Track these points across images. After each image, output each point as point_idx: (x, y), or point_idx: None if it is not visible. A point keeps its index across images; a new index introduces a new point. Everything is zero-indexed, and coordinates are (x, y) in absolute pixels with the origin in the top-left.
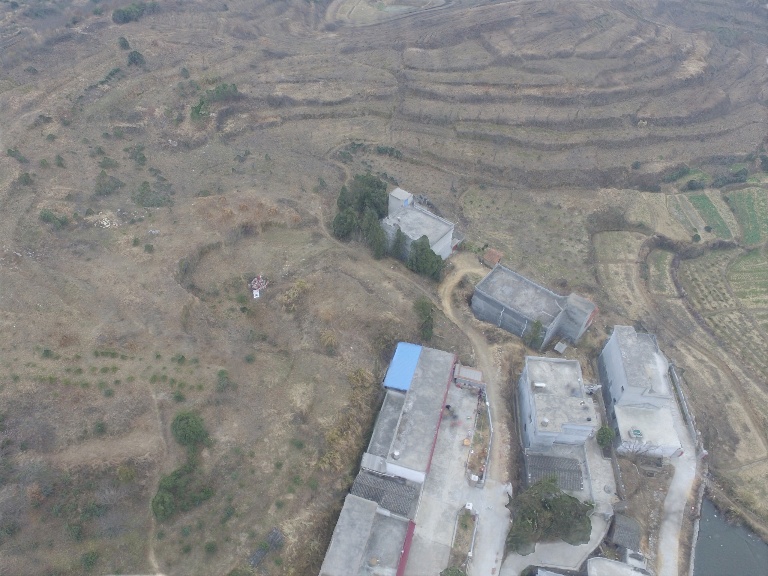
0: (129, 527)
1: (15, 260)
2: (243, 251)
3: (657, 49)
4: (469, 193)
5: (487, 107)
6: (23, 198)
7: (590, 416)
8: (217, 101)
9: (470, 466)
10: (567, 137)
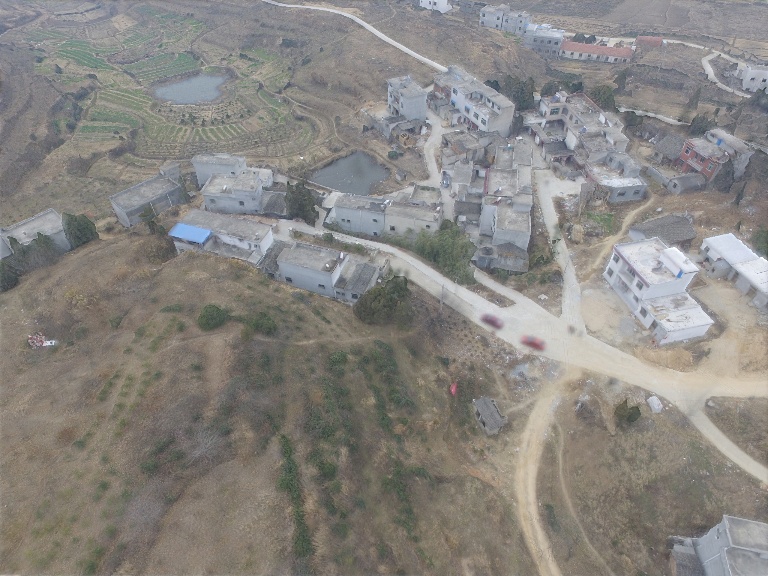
0: None
1: None
2: None
3: None
4: None
5: None
6: None
7: (252, 172)
8: None
9: None
10: None
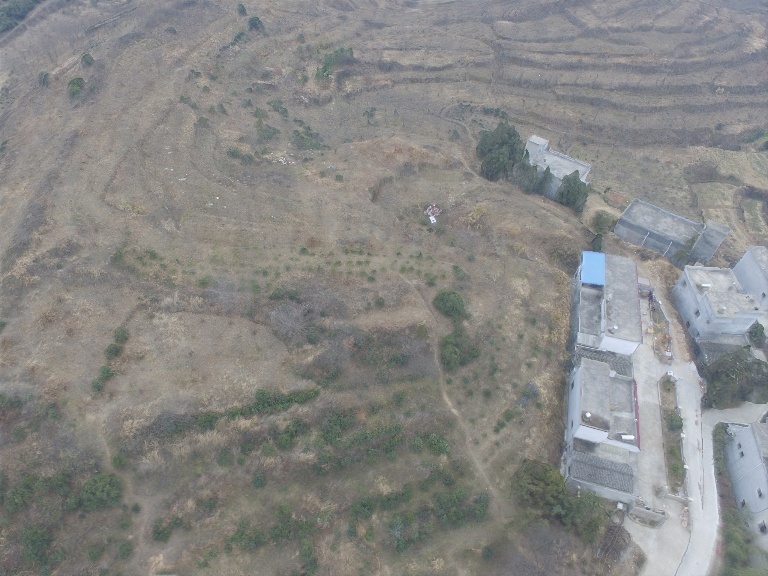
0: (425, 373)
1: (230, 185)
2: (411, 185)
3: (722, 26)
4: (573, 149)
5: (582, 73)
6: (207, 138)
7: (756, 306)
8: (333, 64)
9: (657, 348)
10: (656, 101)
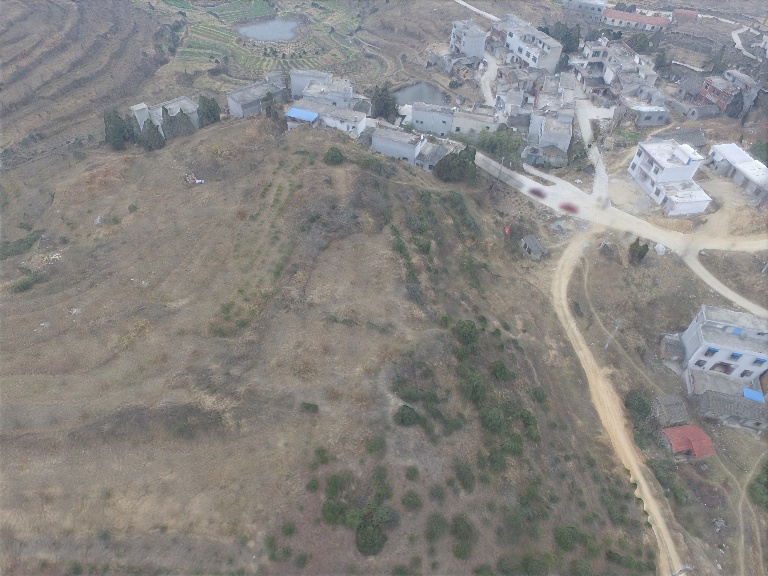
0: None
1: (103, 277)
2: (150, 182)
3: None
4: None
5: (34, 74)
6: None
7: (344, 80)
8: None
9: None
10: (99, 61)
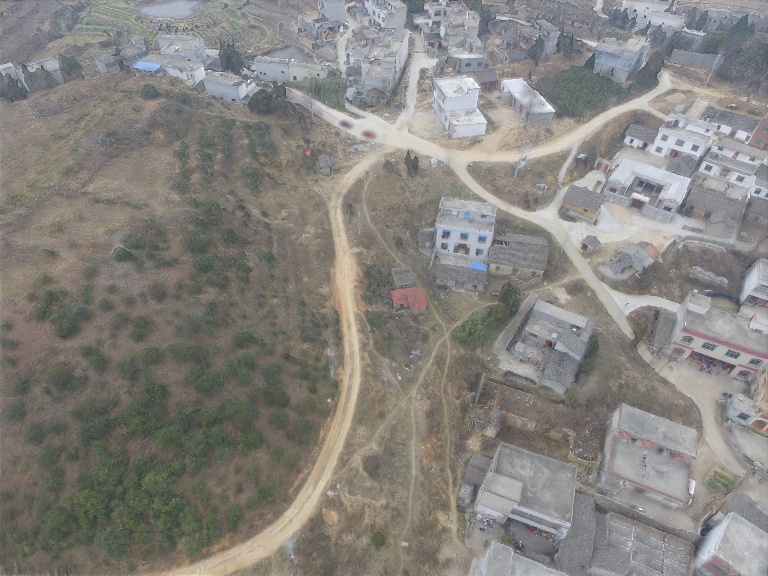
0: None
1: None
2: (0, 124)
3: None
4: None
5: None
6: None
7: None
8: None
9: None
10: None
